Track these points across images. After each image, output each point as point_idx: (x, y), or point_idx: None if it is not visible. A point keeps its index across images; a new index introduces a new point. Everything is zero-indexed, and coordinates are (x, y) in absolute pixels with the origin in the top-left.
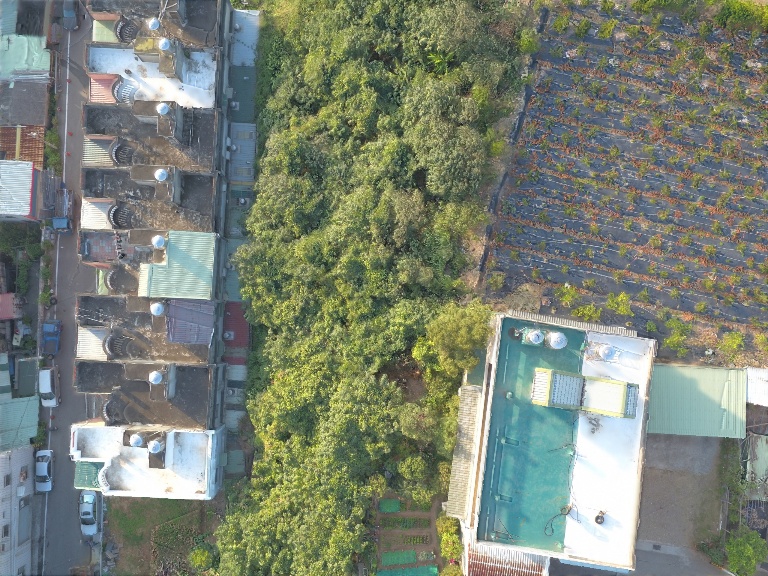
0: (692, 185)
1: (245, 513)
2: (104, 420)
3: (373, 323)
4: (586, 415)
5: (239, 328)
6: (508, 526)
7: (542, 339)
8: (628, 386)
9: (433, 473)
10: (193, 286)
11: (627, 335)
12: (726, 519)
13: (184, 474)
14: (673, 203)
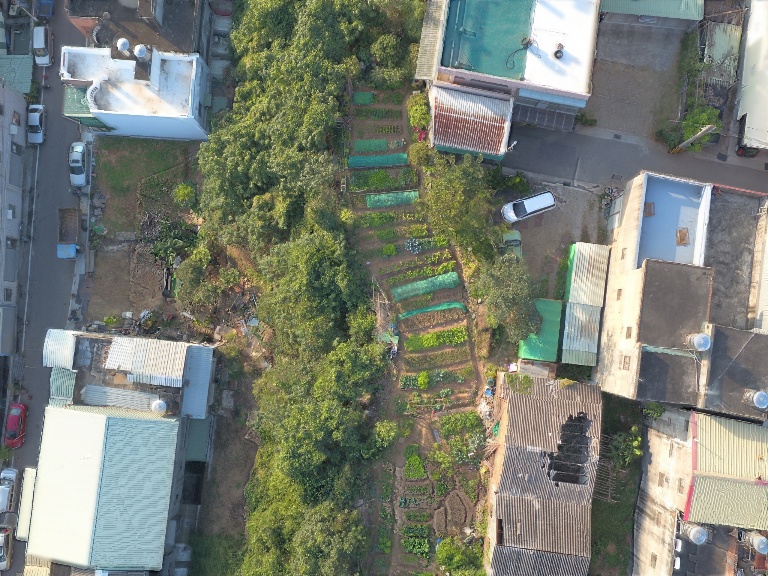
0: None
1: (226, 127)
2: (94, 42)
3: None
4: None
5: None
6: (472, 59)
7: None
8: None
9: (405, 54)
10: None
11: None
12: (684, 106)
13: (169, 100)
14: None
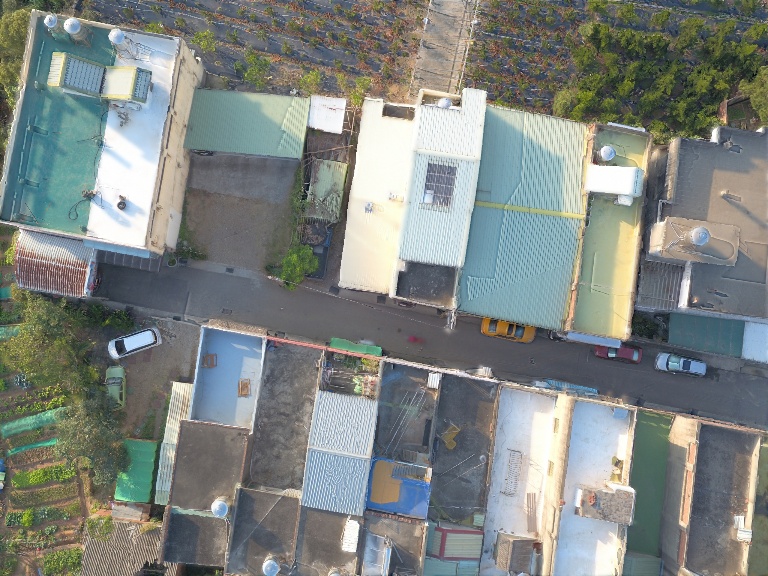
0: None
1: None
2: None
3: None
4: (116, 109)
5: None
6: (34, 210)
7: (55, 22)
8: (137, 70)
9: None
10: None
11: (154, 33)
12: None
13: None
14: None
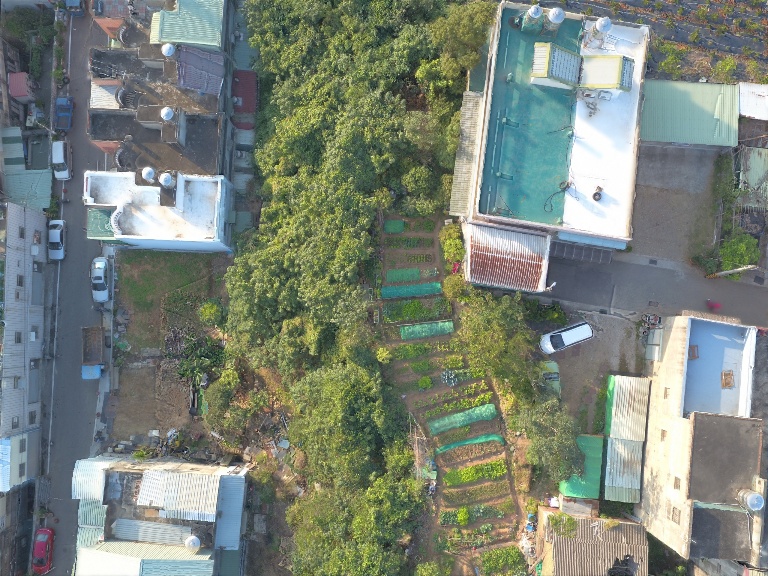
0: None
1: (253, 252)
2: (116, 166)
3: (378, 51)
4: (584, 99)
5: (247, 95)
6: (509, 203)
7: (541, 12)
8: (624, 58)
9: (436, 186)
10: (203, 30)
11: None
12: (720, 231)
13: (194, 222)
14: None
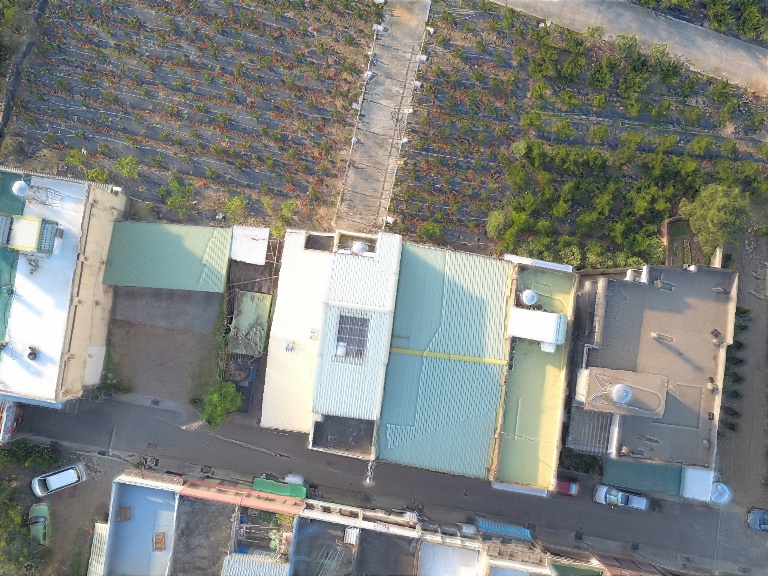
0: (209, 54)
1: None
2: None
3: None
4: (26, 256)
5: None
6: None
7: None
8: (43, 222)
9: None
10: None
11: None
12: None
13: None
14: (191, 72)
